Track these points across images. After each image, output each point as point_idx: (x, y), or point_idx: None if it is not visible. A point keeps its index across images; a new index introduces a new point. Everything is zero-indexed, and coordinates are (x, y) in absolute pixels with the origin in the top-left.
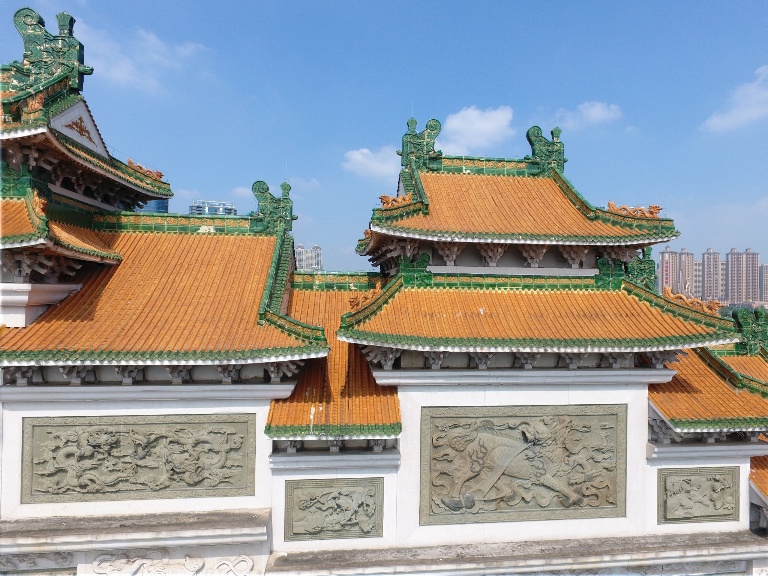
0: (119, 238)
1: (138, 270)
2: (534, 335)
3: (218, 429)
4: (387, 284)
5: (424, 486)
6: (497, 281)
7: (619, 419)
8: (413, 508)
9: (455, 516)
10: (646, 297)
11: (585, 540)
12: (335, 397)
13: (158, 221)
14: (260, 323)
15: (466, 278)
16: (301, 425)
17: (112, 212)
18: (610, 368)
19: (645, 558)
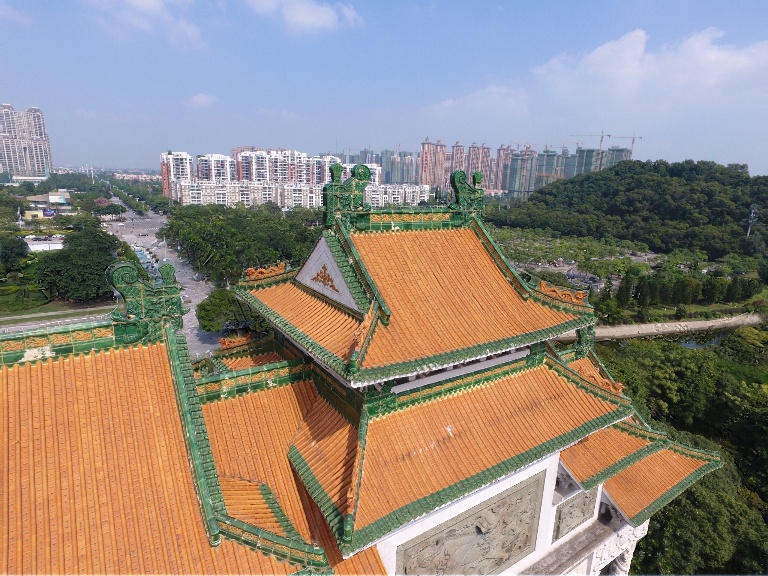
0: None
1: None
2: (503, 455)
3: None
4: (360, 432)
5: None
6: (453, 384)
7: (540, 482)
8: None
9: None
10: (565, 373)
11: None
12: None
13: None
14: (215, 545)
15: (427, 390)
16: None
17: None
18: None
19: None
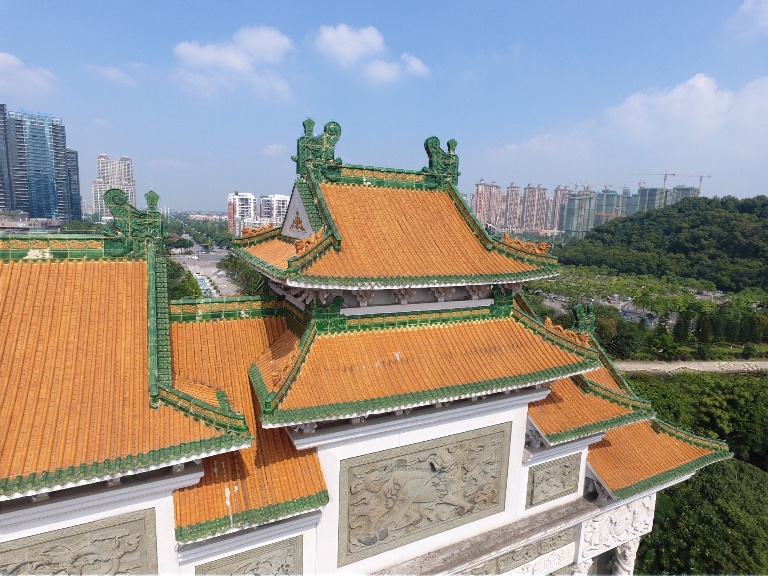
0: None
1: None
2: (449, 382)
3: (105, 535)
4: (302, 338)
5: (342, 532)
6: (408, 318)
7: (505, 434)
8: (332, 555)
9: (370, 550)
10: (531, 325)
11: (475, 538)
12: (249, 469)
13: None
14: (154, 406)
15: (379, 318)
16: (219, 518)
17: None
18: (503, 395)
19: (519, 544)
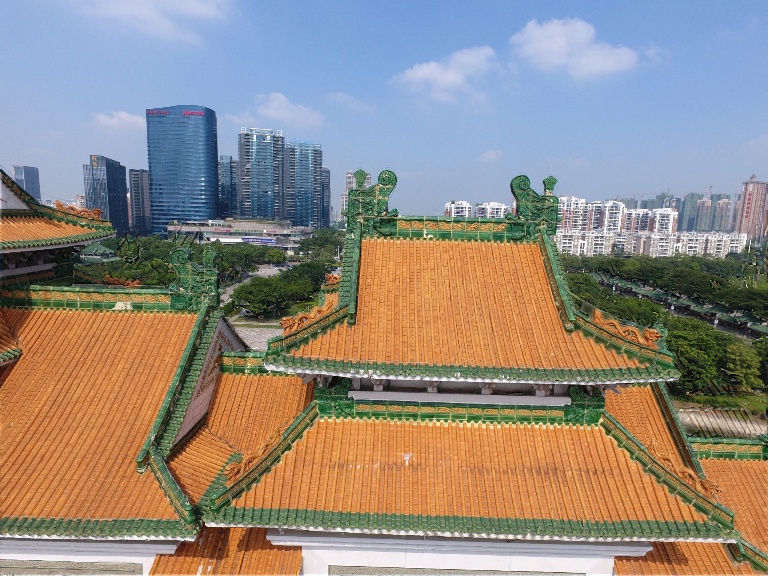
0: (28, 318)
1: (35, 371)
2: (461, 509)
3: None
4: None
5: None
6: (436, 411)
7: None
8: None
9: None
10: (627, 445)
11: None
12: (230, 549)
13: (70, 297)
14: (139, 471)
15: (397, 407)
16: None
17: (20, 287)
18: None
19: None
